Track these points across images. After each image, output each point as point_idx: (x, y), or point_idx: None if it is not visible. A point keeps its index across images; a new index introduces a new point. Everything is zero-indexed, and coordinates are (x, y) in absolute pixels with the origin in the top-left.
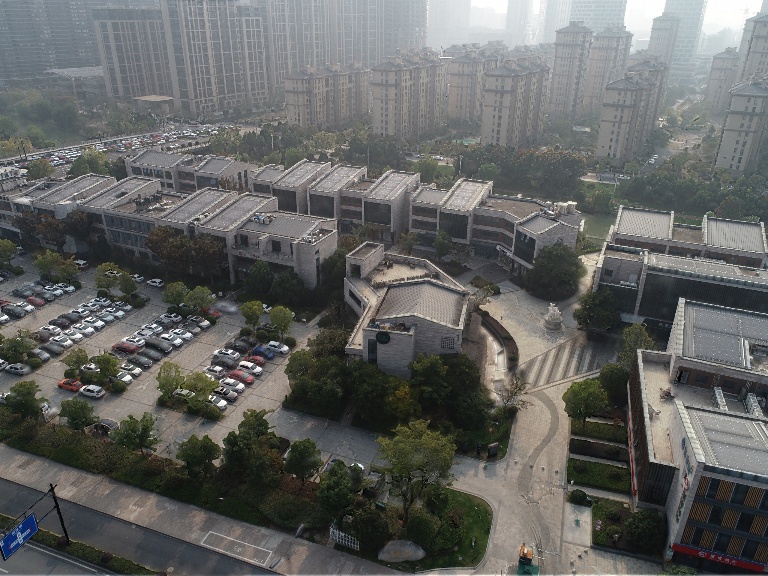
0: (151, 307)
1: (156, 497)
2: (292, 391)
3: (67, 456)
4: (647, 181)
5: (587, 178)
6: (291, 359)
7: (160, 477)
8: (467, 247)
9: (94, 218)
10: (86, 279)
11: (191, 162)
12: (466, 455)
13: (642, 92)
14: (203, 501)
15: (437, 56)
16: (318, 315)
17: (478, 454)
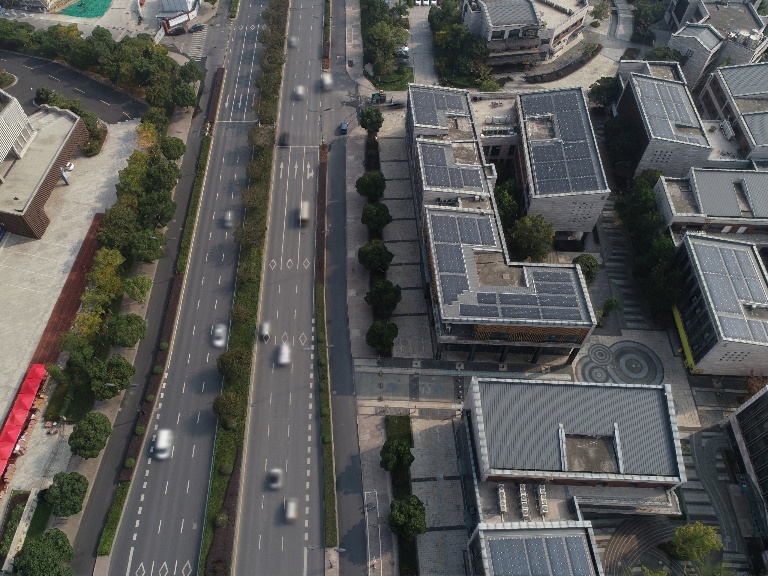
0: None
1: (359, 10)
2: None
3: None
4: None
5: None
6: None
7: None
8: None
9: None
10: None
11: None
12: (439, 77)
13: None
14: (363, 20)
15: None
16: None
17: (441, 80)
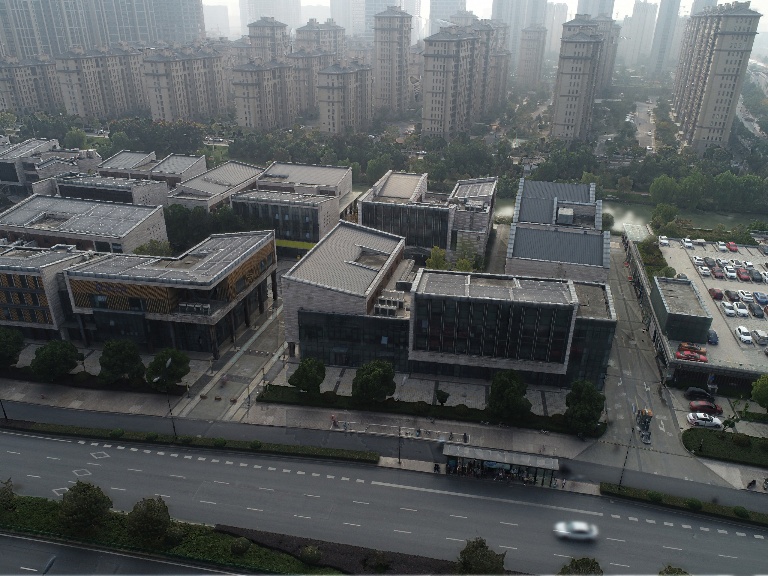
0: None
1: None
2: None
3: None
4: (244, 142)
5: (220, 143)
6: None
7: None
8: None
9: None
10: None
11: None
12: None
13: (262, 73)
14: None
15: (132, 47)
16: None
17: None
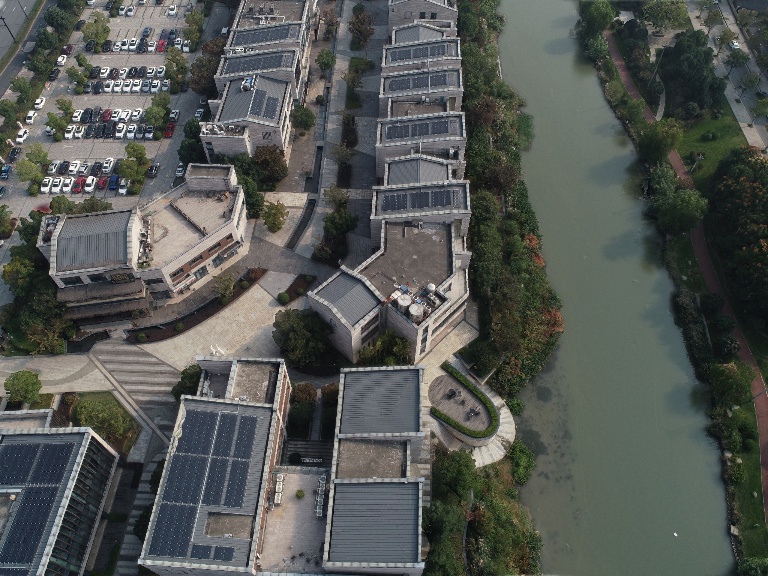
0: (174, 98)
1: None
2: None
3: None
4: None
5: None
6: None
7: None
8: (319, 245)
9: None
10: None
11: None
12: (3, 333)
13: None
14: None
15: None
16: None
17: (3, 339)
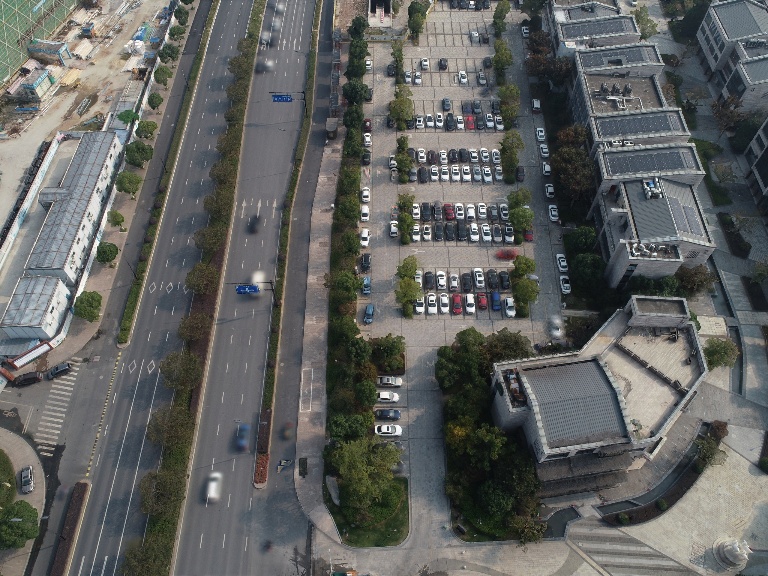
0: (513, 189)
1: (326, 325)
2: (439, 349)
3: (334, 259)
4: None
5: None
6: (465, 331)
7: (338, 317)
8: None
9: (576, 72)
10: (523, 123)
11: (759, 45)
12: (452, 508)
13: None
14: (331, 352)
15: None
16: (585, 311)
17: (457, 518)
